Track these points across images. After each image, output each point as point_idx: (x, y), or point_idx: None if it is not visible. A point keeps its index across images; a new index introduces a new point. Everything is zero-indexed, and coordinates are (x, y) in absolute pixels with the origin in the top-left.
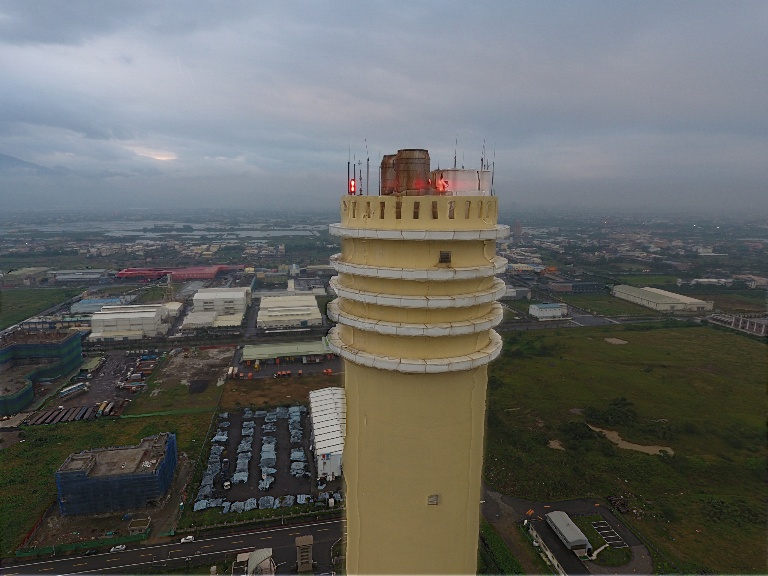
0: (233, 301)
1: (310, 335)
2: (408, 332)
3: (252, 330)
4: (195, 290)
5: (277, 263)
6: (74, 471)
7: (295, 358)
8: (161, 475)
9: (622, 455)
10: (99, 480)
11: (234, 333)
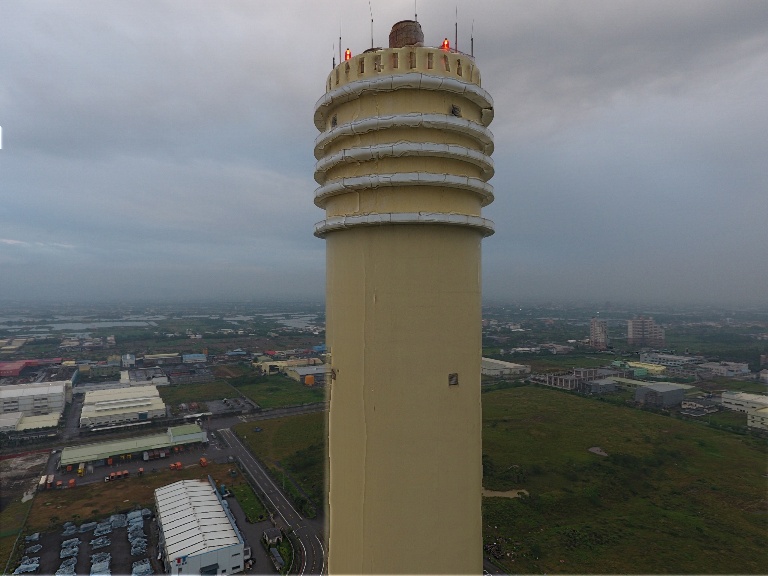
0: (47, 398)
1: (151, 428)
2: (430, 177)
3: (73, 430)
4: None
5: (106, 354)
6: None
7: (133, 455)
8: None
9: (488, 503)
10: None
11: (48, 435)
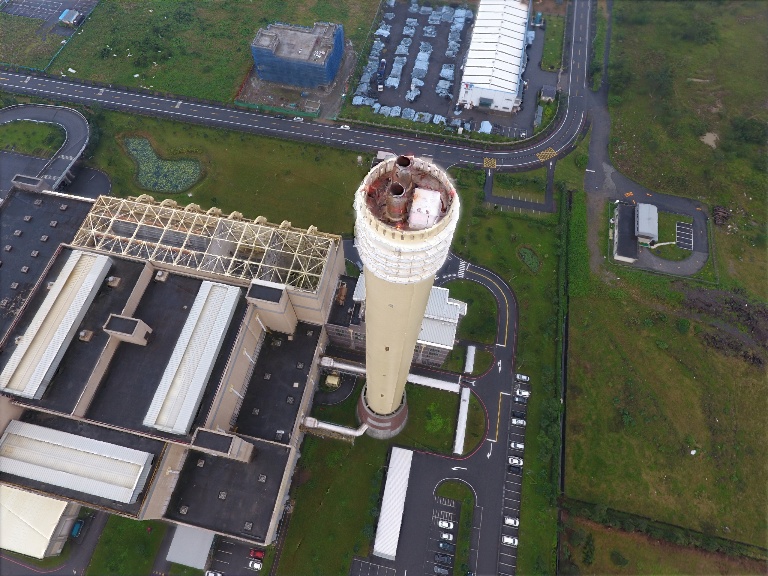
0: None
1: None
2: (377, 267)
3: None
4: None
5: None
6: (264, 48)
7: None
8: (329, 67)
9: None
10: (283, 60)
11: None
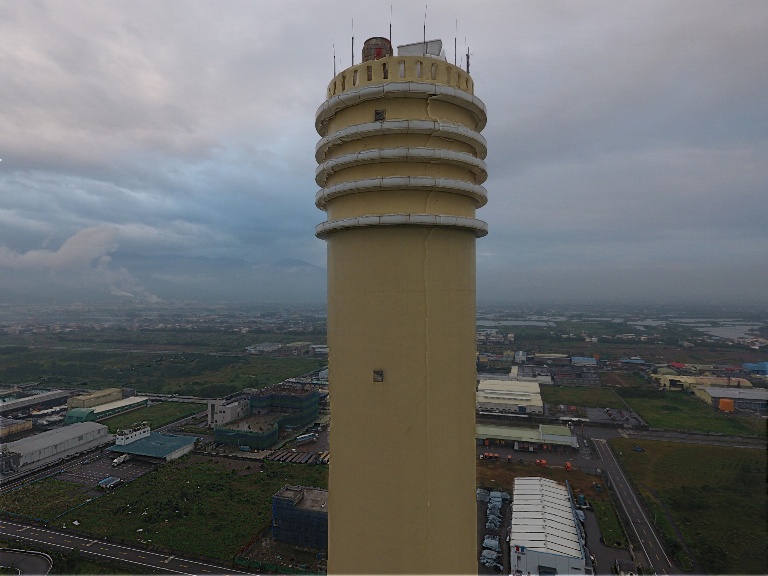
0: None
1: (527, 422)
2: (344, 187)
3: None
4: None
5: (503, 349)
6: (285, 499)
7: (506, 442)
8: None
9: None
10: (303, 513)
11: None
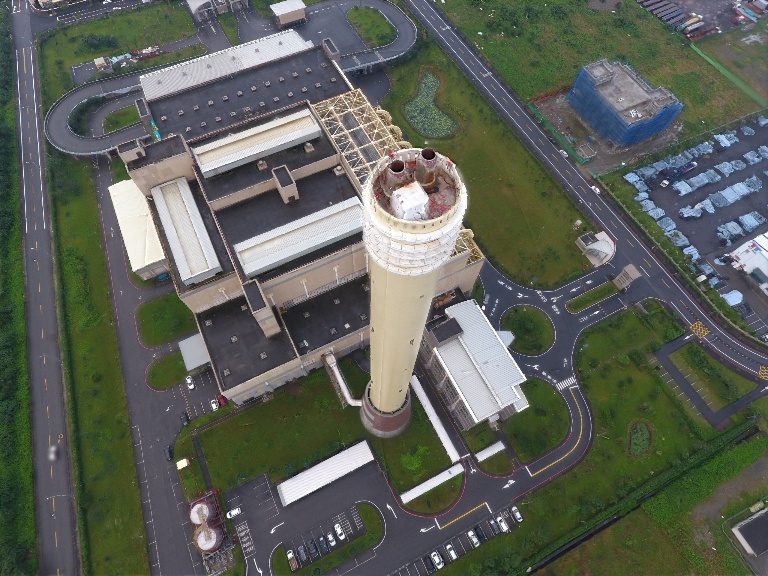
0: None
1: None
2: None
3: None
4: None
5: None
6: (592, 76)
7: None
8: (634, 130)
9: None
10: (598, 96)
11: None
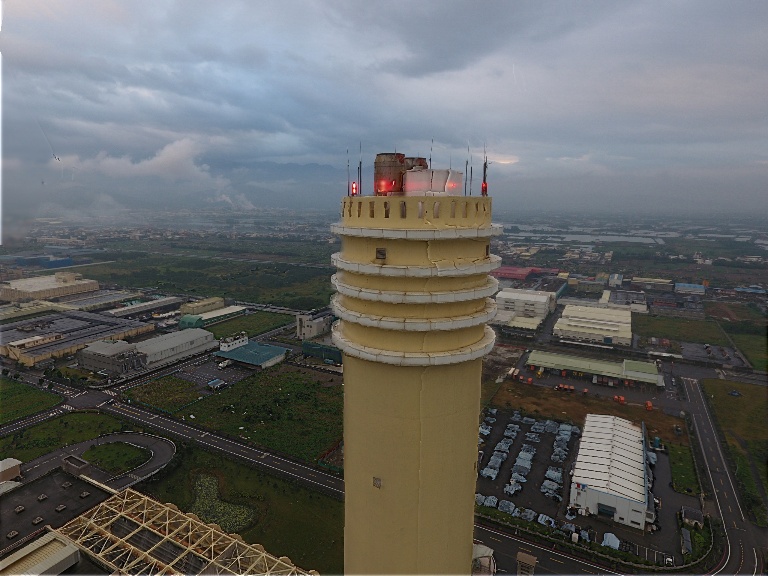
0: (534, 304)
1: (611, 354)
2: (348, 318)
3: (547, 336)
4: (500, 288)
5: (596, 271)
6: None
7: (584, 375)
8: None
9: None
10: None
11: (527, 336)
